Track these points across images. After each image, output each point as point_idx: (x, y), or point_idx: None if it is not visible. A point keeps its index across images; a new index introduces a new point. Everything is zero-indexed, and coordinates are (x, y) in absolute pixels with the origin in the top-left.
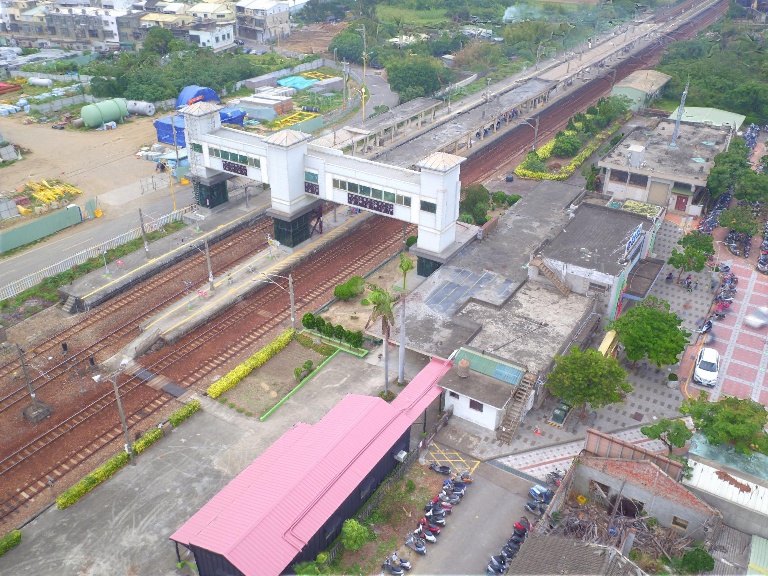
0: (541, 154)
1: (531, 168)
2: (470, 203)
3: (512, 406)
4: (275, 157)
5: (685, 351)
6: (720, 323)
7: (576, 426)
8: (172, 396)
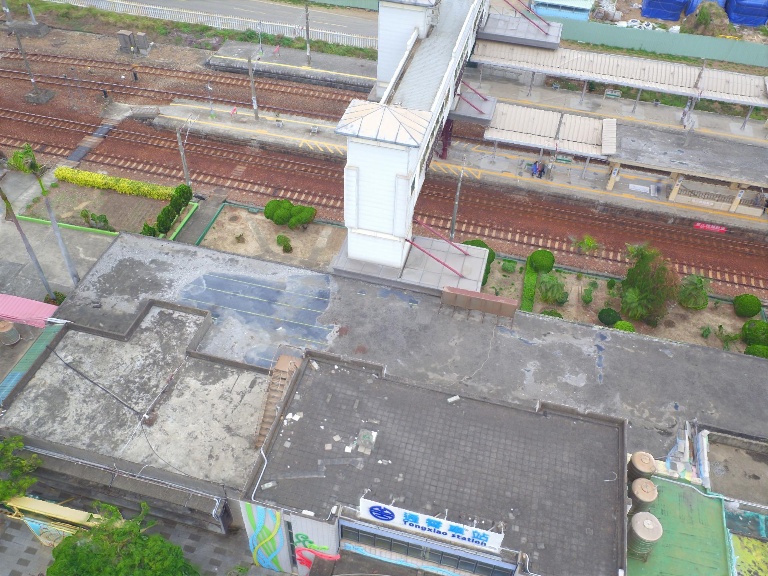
0: None
1: None
2: (628, 279)
3: None
4: None
5: None
6: None
7: None
8: (68, 155)
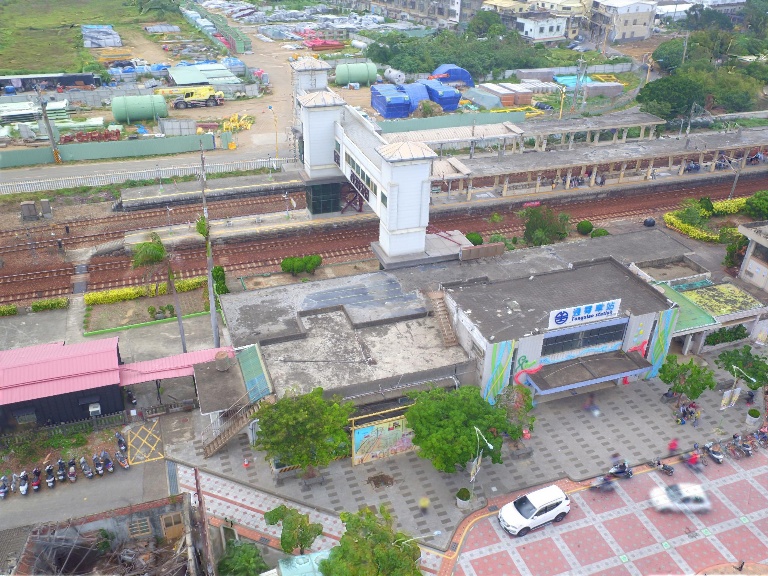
0: (721, 206)
1: (683, 217)
2: (530, 227)
3: (236, 421)
4: (305, 117)
5: (550, 481)
6: (660, 477)
7: (291, 480)
8: (72, 291)
